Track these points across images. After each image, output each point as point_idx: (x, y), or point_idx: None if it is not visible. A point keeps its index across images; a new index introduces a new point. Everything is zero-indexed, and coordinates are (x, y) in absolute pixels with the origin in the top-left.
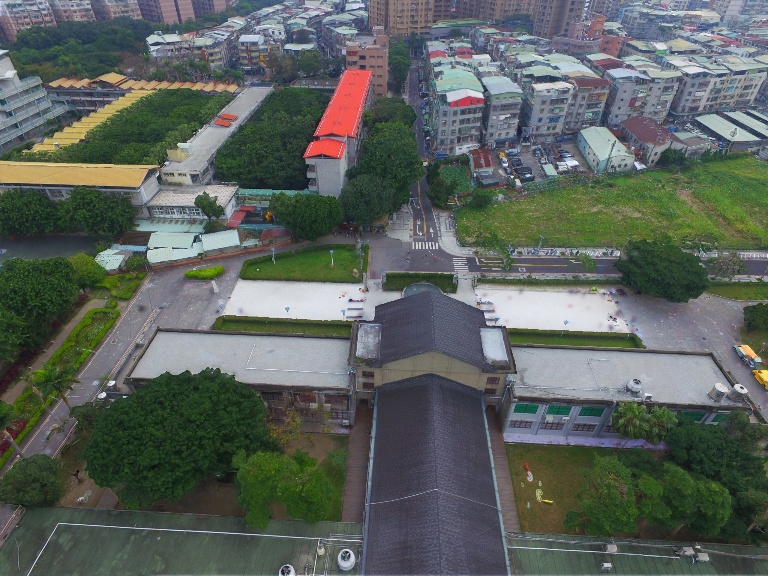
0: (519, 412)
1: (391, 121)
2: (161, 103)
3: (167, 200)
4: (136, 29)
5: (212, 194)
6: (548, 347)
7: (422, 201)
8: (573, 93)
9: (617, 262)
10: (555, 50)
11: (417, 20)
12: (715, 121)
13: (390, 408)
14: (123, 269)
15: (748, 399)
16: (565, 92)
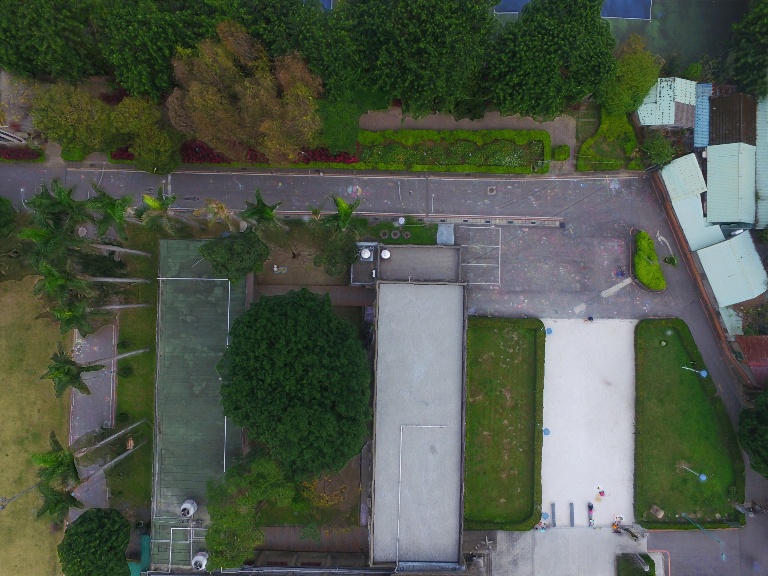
0: None
1: None
2: None
3: None
4: None
5: None
6: None
7: None
8: None
9: None
10: None
11: None
12: None
13: None
14: (650, 127)
15: None
16: None
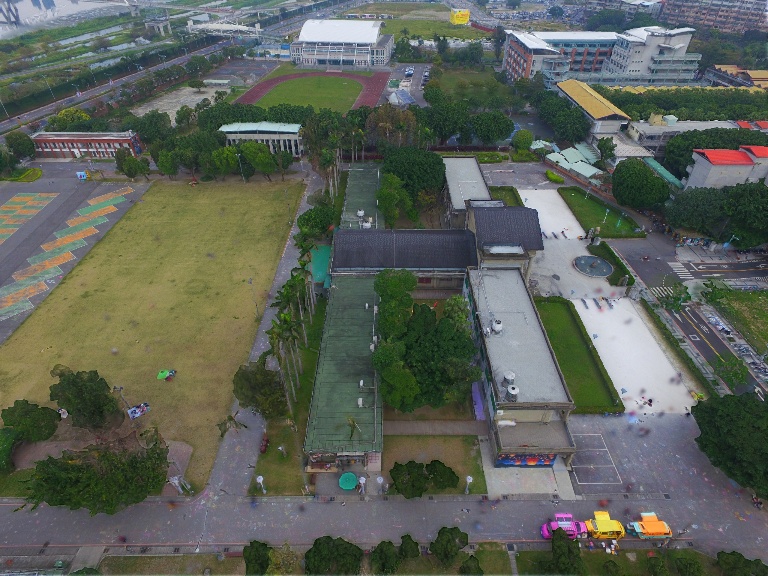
0: None
1: None
2: (741, 97)
3: None
4: None
5: (631, 150)
6: None
7: None
8: None
9: None
10: None
11: None
12: None
13: None
14: None
15: (535, 446)
16: None
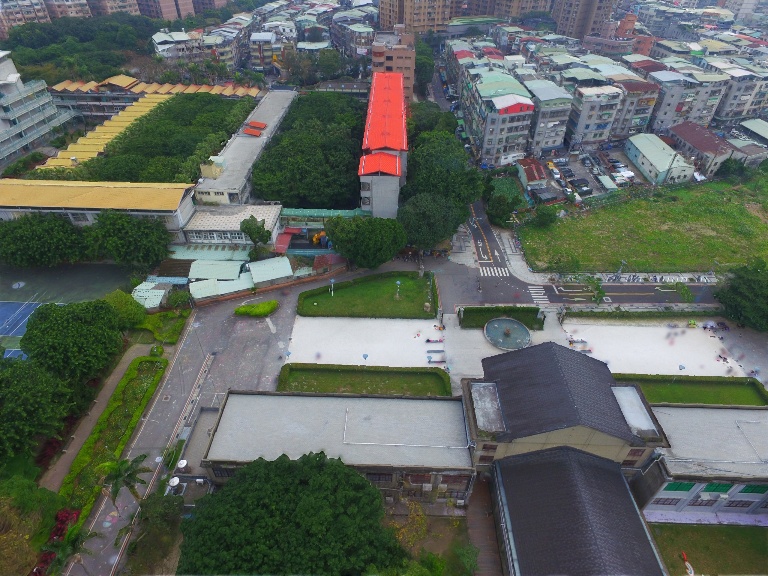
0: (669, 490)
1: (436, 130)
2: (181, 109)
3: (205, 223)
4: (136, 25)
5: (254, 215)
6: (686, 406)
7: (478, 219)
8: (621, 98)
9: (720, 293)
10: (587, 50)
11: (434, 17)
12: (763, 126)
13: (522, 490)
14: (163, 305)
15: None
16: (615, 97)
